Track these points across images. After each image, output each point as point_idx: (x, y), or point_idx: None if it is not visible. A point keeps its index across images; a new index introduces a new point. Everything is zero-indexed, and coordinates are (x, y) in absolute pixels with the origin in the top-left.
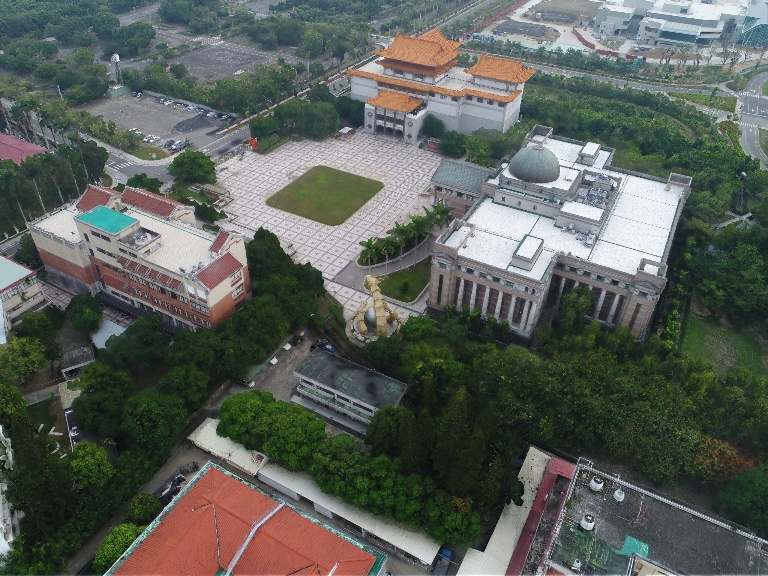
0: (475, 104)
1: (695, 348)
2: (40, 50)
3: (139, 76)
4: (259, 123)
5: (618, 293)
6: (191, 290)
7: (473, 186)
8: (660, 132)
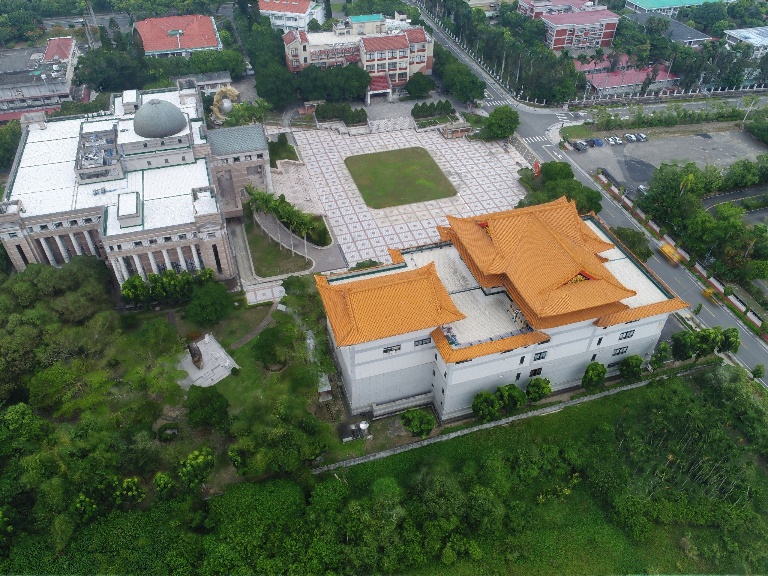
0: None
1: None
2: None
3: None
4: None
5: None
6: None
7: None
8: None
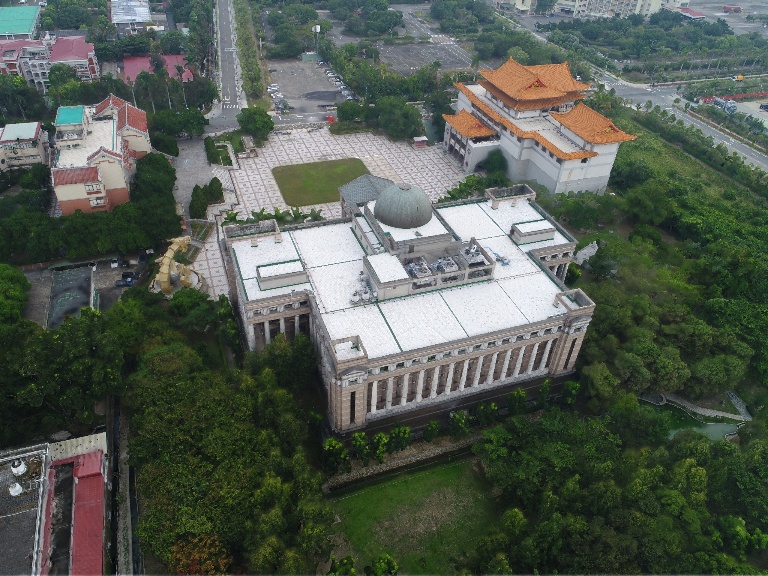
0: (540, 152)
1: (414, 488)
2: (300, 14)
3: (331, 49)
4: (345, 106)
5: None
6: None
7: None
8: (742, 265)
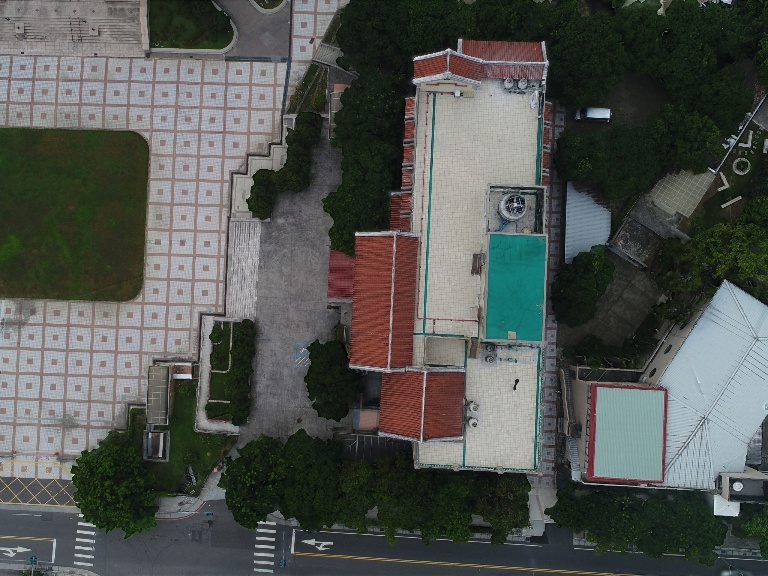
0: None
1: None
2: None
3: None
4: None
5: None
6: None
7: None
8: None
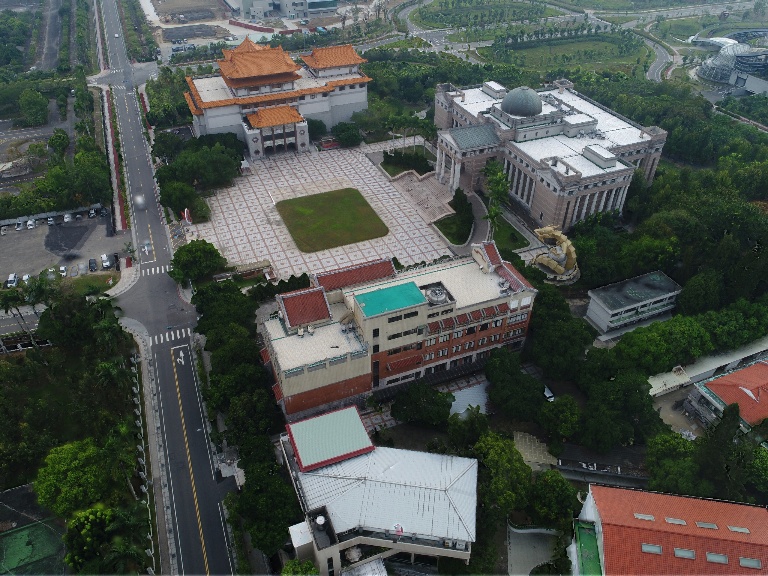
0: (338, 93)
1: None
2: None
3: None
4: (179, 192)
5: (640, 158)
6: (514, 305)
7: (491, 139)
8: (458, 68)
